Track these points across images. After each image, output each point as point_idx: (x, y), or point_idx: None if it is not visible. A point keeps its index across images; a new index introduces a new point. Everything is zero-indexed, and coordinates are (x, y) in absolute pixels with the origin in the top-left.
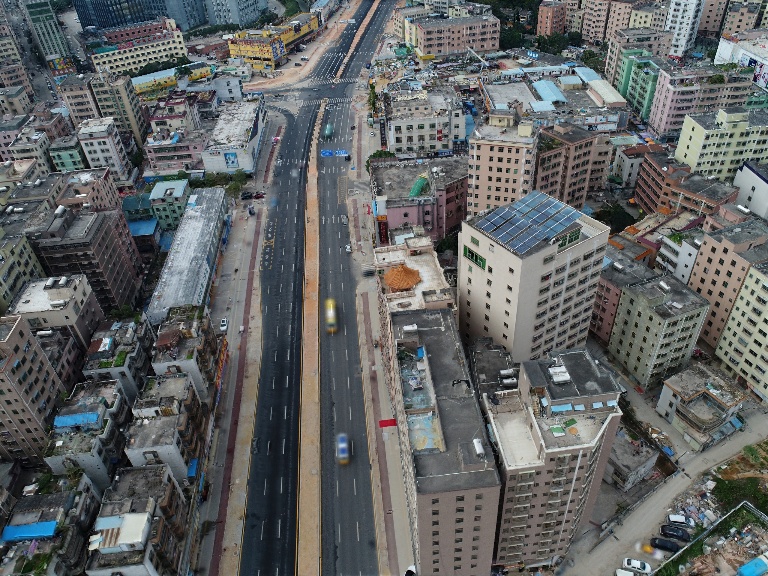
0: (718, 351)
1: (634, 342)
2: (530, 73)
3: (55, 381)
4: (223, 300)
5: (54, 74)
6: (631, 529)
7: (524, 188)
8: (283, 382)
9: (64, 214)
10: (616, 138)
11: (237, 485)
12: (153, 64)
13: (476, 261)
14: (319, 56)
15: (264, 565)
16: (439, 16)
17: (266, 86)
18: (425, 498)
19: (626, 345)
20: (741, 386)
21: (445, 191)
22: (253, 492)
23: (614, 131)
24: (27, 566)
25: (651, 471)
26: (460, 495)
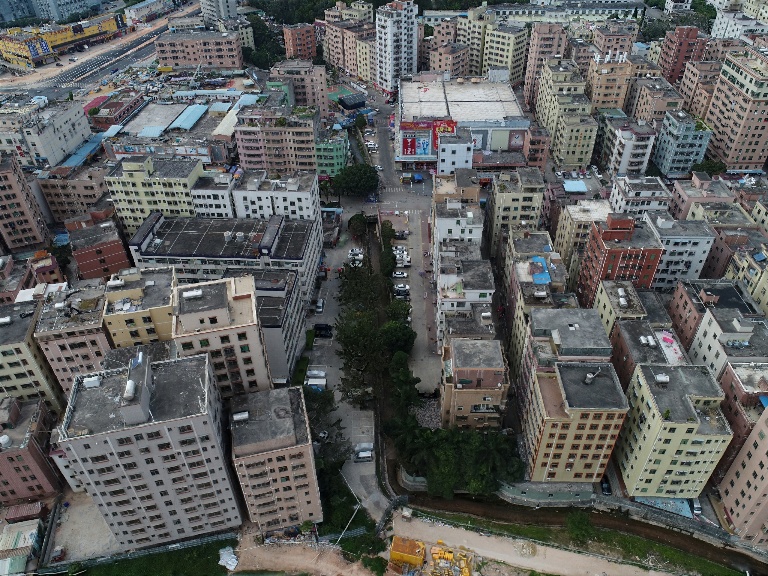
0: None
1: None
2: (200, 96)
3: None
4: None
5: None
6: None
7: None
8: None
9: None
10: None
11: None
12: None
13: None
14: (88, 58)
15: None
16: (206, 28)
17: (2, 84)
18: None
19: None
20: None
21: None
22: None
23: (209, 164)
24: None
25: None
26: None
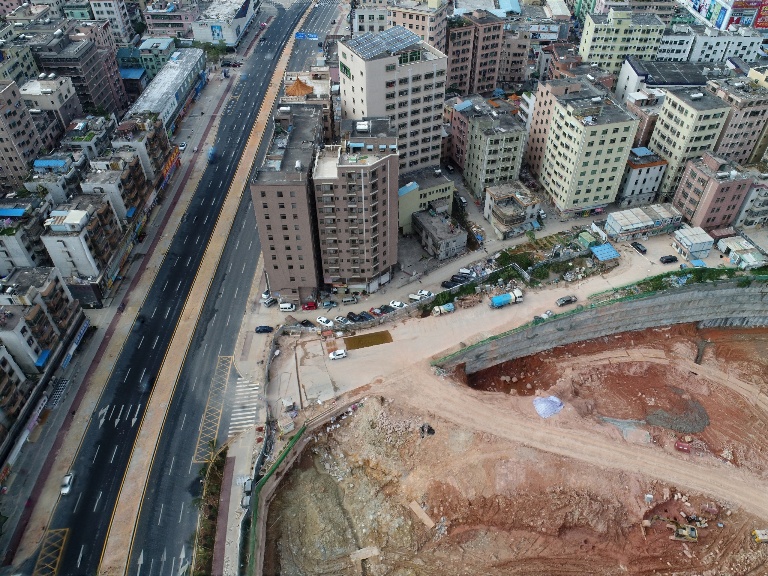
0: (540, 178)
1: (474, 162)
2: None
3: (39, 142)
4: (187, 131)
5: None
6: (433, 278)
7: None
8: (217, 184)
9: (61, 36)
10: None
11: (166, 237)
12: None
13: (346, 73)
14: None
15: (172, 279)
16: None
17: None
18: (256, 190)
19: (471, 167)
20: (552, 205)
21: None
22: (176, 242)
23: (555, 41)
24: (3, 232)
25: (464, 250)
26: (279, 191)
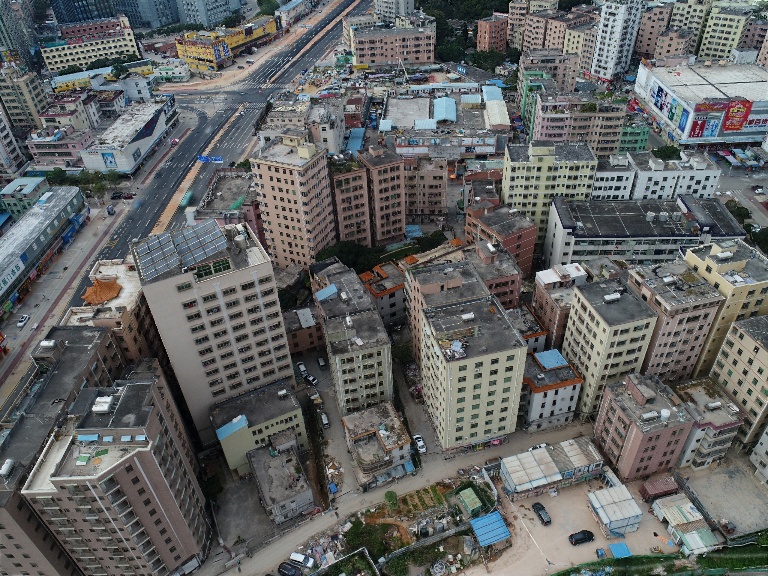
0: (422, 391)
1: (333, 375)
2: (438, 89)
3: None
4: (37, 297)
5: (1, 65)
6: (257, 562)
7: (305, 210)
8: None
9: None
10: (491, 161)
11: None
12: (102, 60)
13: None
14: (265, 60)
15: None
16: (385, 26)
17: (199, 87)
18: None
19: None
20: None
21: (252, 206)
22: None
23: (493, 154)
24: None
25: (312, 506)
26: None
